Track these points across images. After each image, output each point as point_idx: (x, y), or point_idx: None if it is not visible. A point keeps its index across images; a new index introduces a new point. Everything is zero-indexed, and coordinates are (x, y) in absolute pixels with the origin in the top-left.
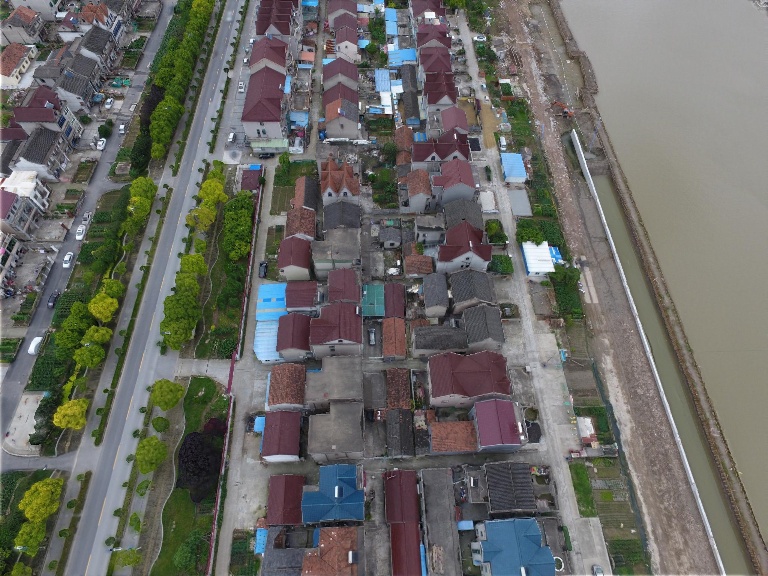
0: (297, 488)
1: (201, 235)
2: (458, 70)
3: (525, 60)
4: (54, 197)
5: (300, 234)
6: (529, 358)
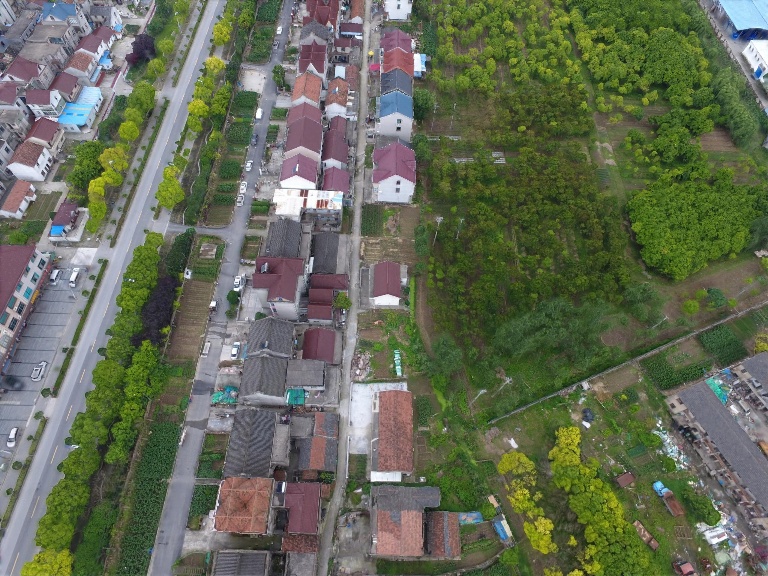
0: None
1: (131, 175)
2: None
3: None
4: None
5: None
6: None
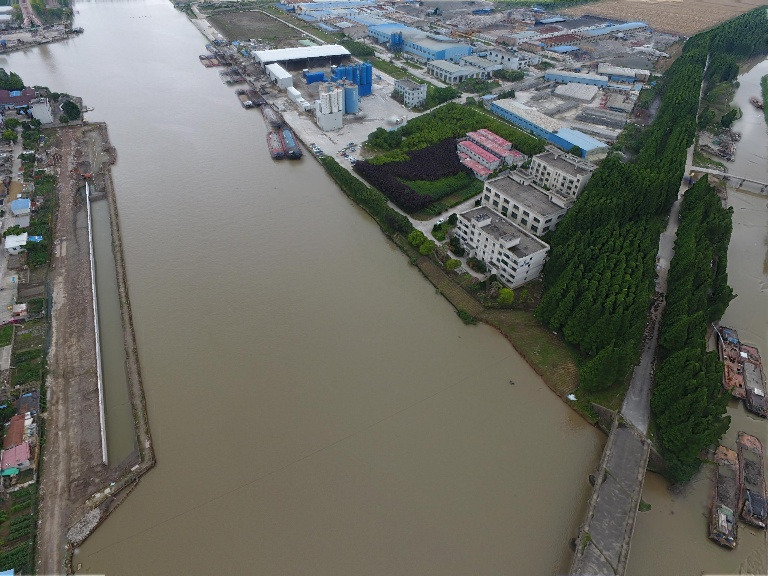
0: None
1: None
2: (1, 170)
3: (65, 157)
4: None
5: None
6: None
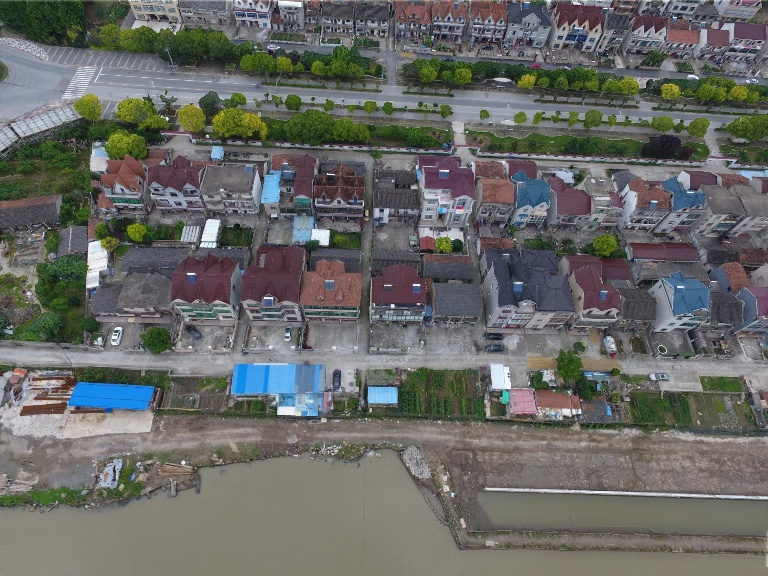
0: None
1: None
2: None
3: None
4: None
5: None
6: None
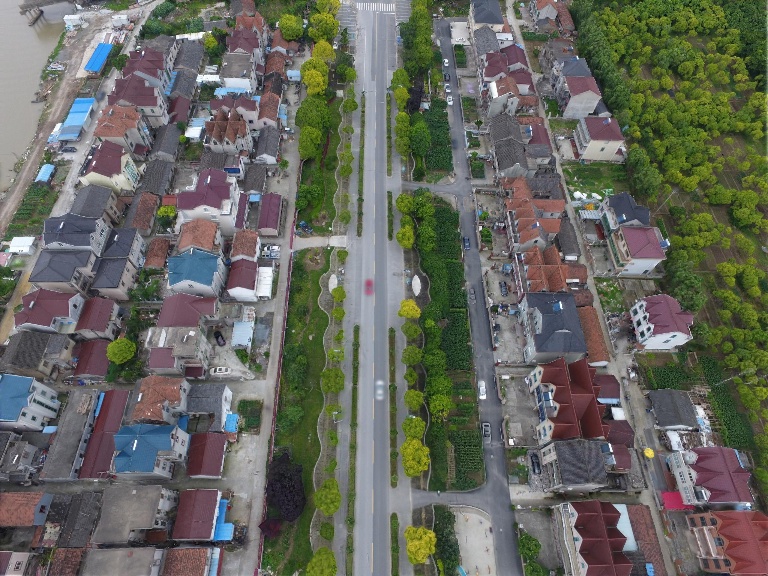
0: (194, 464)
1: None
2: None
3: None
4: None
5: None
6: None
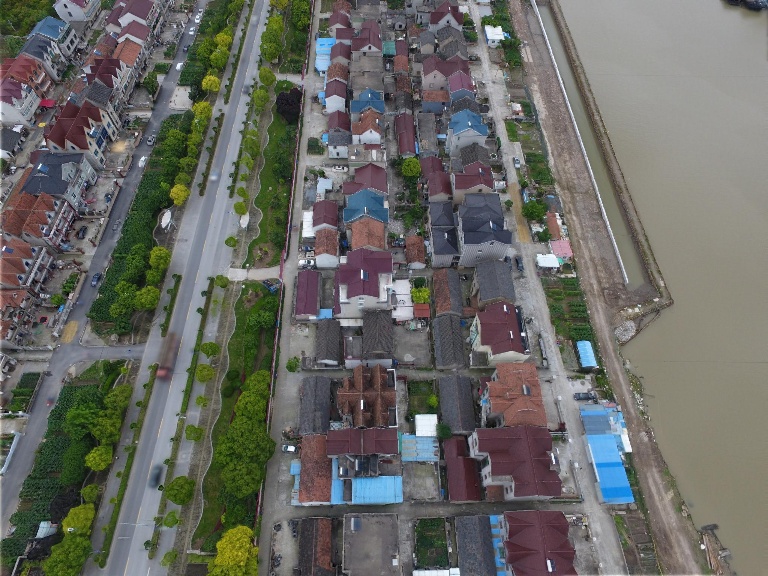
0: (345, 117)
1: None
2: None
3: None
4: (177, 2)
5: (342, 11)
6: (485, 79)
